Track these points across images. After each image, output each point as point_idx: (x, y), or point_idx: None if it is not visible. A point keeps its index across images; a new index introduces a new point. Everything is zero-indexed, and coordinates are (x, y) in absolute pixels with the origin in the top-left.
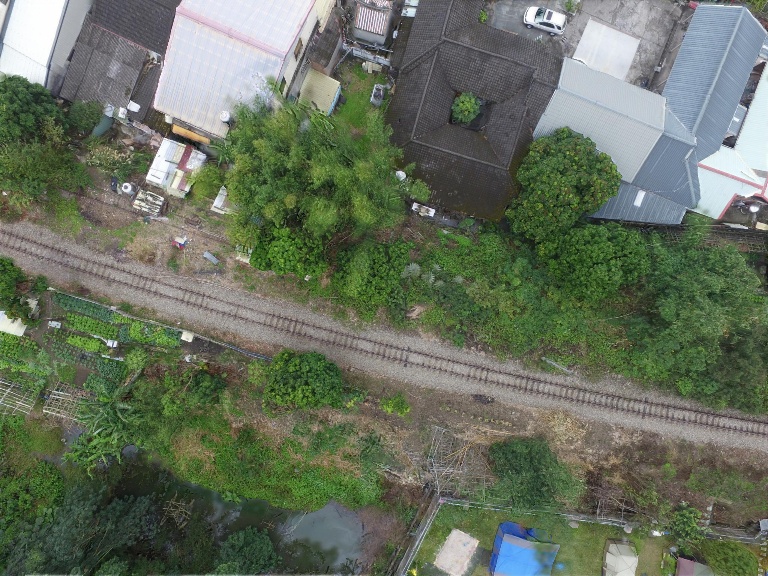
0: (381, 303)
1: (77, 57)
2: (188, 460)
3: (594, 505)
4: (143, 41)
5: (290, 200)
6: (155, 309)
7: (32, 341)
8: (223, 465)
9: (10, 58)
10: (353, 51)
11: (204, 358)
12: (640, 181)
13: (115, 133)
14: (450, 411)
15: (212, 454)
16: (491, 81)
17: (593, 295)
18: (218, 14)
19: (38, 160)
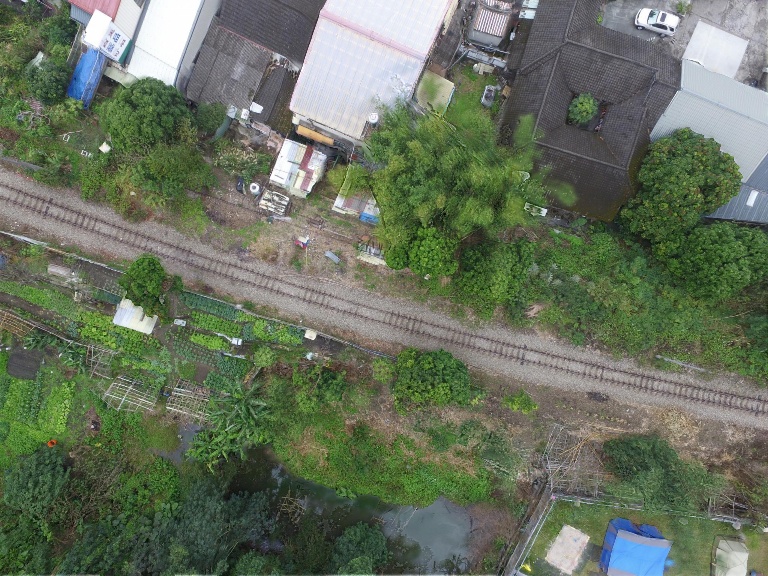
0: (500, 302)
1: (202, 59)
2: (302, 456)
3: (702, 502)
4: (269, 43)
5: (441, 200)
6: (277, 307)
7: (155, 339)
8: (336, 461)
9: (140, 60)
10: (468, 53)
11: (325, 356)
12: (754, 181)
13: (233, 134)
14: (566, 408)
15: (326, 450)
16: (610, 82)
17: (722, 294)
18: (360, 17)
19: (178, 161)
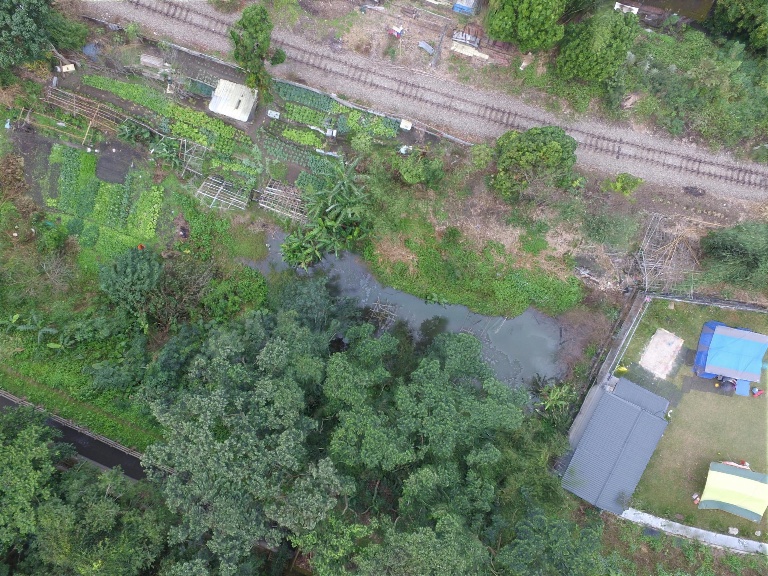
0: (596, 91)
1: None
2: (392, 263)
3: None
4: None
5: None
6: (370, 101)
7: (246, 136)
8: (426, 269)
9: None
10: None
11: (420, 148)
12: None
13: None
14: (663, 202)
15: (415, 257)
16: None
17: None
18: None
19: None
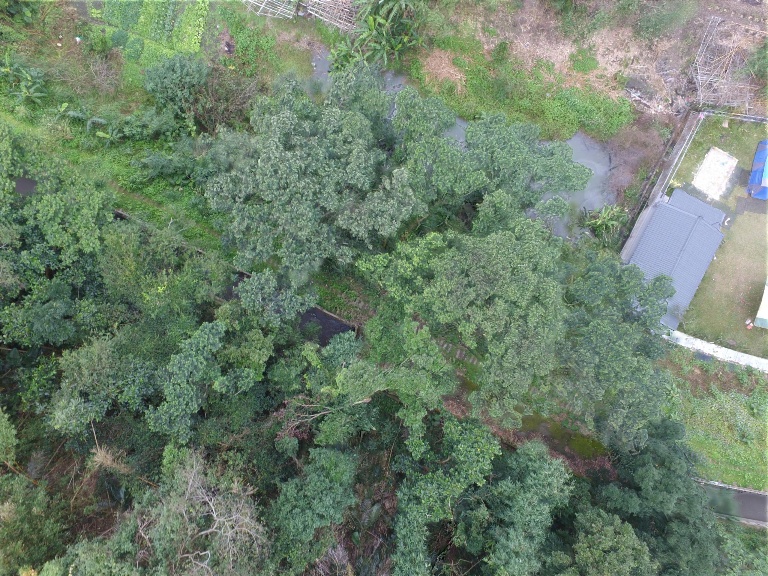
0: None
1: None
2: (440, 82)
3: None
4: None
5: None
6: None
7: None
8: (474, 88)
9: None
10: None
11: None
12: None
13: None
14: (719, 10)
15: (464, 77)
16: None
17: None
18: None
19: None
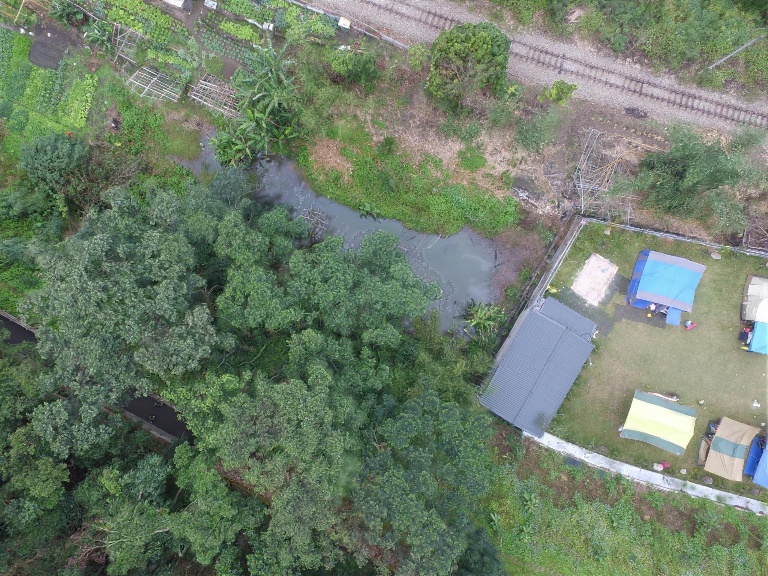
0: (541, 3)
1: None
2: (327, 170)
3: (735, 242)
4: None
5: None
6: None
7: (183, 27)
8: (361, 179)
9: None
10: None
11: (358, 49)
12: None
13: None
14: (603, 121)
15: (351, 167)
16: None
17: None
18: None
19: None
